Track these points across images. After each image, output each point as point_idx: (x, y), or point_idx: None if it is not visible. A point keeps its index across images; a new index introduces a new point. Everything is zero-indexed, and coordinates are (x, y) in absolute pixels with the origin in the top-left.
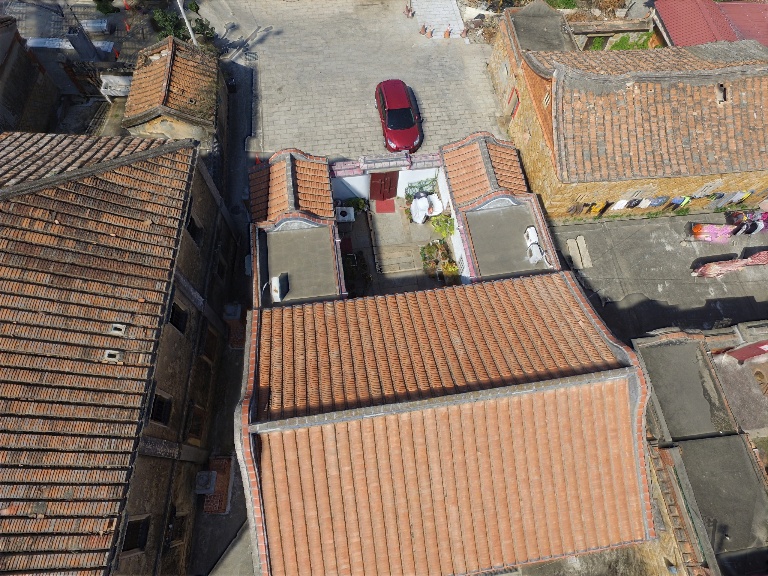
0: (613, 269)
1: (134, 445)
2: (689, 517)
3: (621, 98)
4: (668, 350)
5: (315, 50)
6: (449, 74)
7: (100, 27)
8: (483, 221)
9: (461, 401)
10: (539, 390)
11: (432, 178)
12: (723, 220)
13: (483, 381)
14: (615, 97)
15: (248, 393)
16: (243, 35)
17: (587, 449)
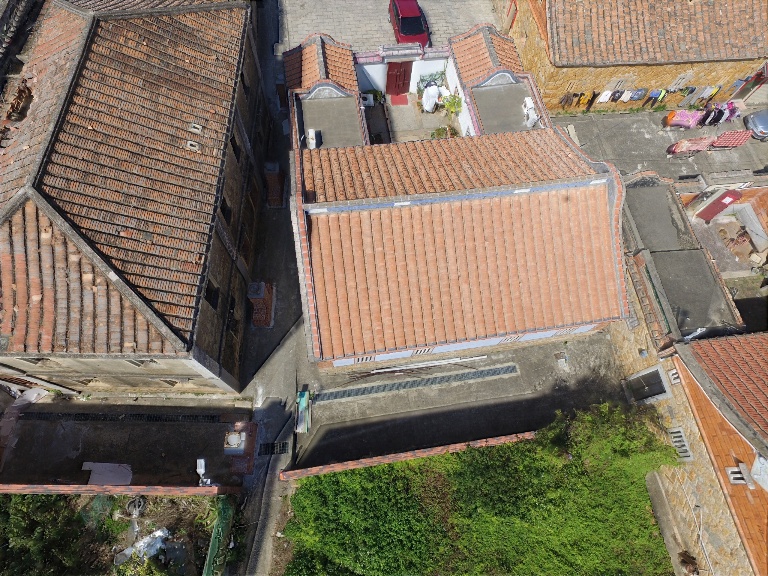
0: (599, 152)
1: (214, 210)
2: (657, 302)
3: None
4: (643, 190)
5: None
6: None
7: None
8: (487, 95)
9: (472, 197)
10: (535, 191)
11: (441, 71)
12: None
13: None
14: None
15: None
16: None
17: (574, 243)
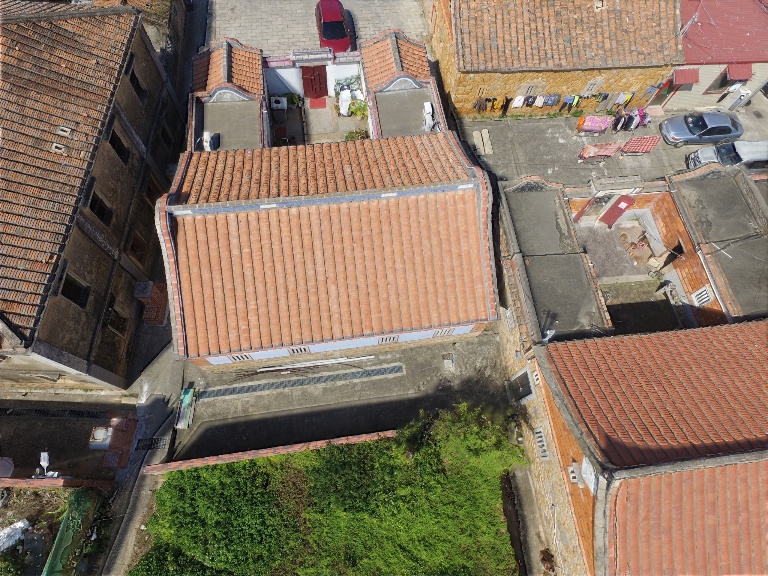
0: (511, 156)
1: (73, 211)
2: (526, 305)
3: (511, 1)
4: (531, 195)
5: None
6: (384, 1)
7: None
8: (390, 100)
9: (339, 200)
10: (403, 195)
11: (356, 75)
12: None
13: None
14: (507, 0)
15: None
16: None
17: (443, 246)
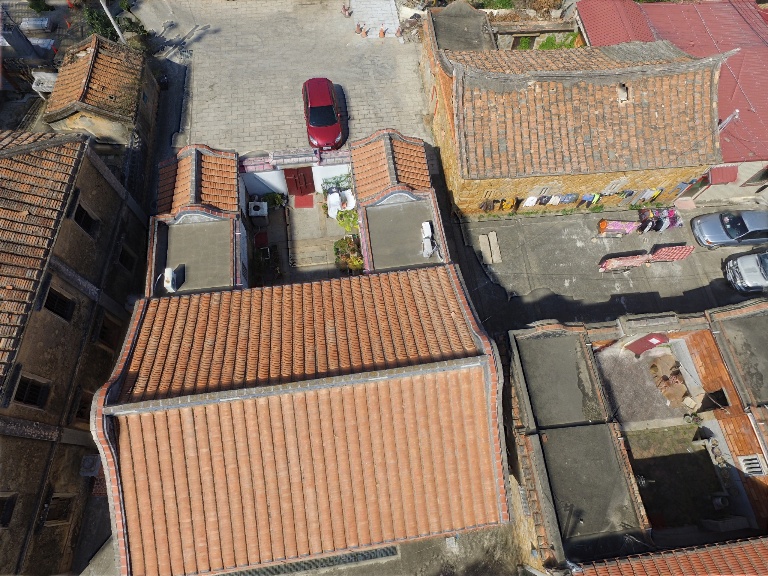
0: (522, 264)
1: None
2: None
3: (523, 97)
4: (548, 342)
5: (250, 48)
6: (380, 73)
7: (41, 25)
8: (383, 216)
9: (317, 387)
10: (394, 377)
11: (346, 174)
12: (636, 217)
13: (343, 368)
14: (517, 96)
15: (113, 377)
16: (180, 33)
17: (443, 435)
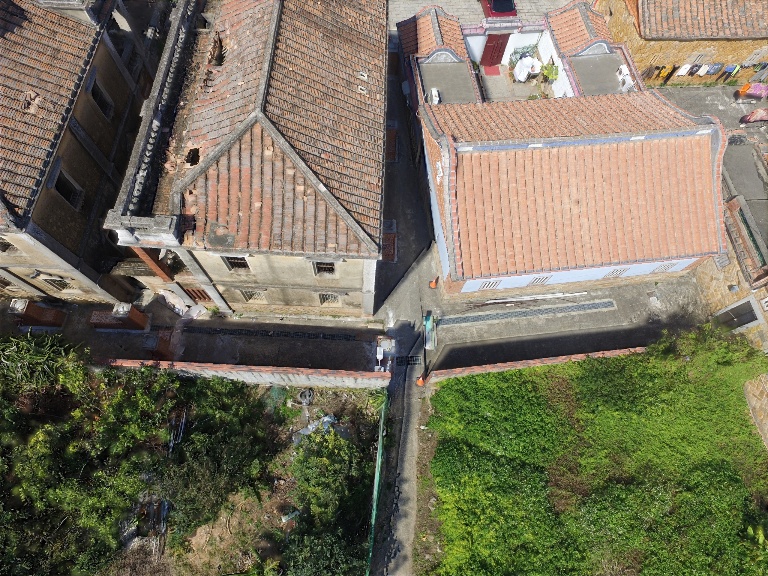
0: None
1: (383, 143)
2: (751, 241)
3: None
4: (731, 148)
5: None
6: None
7: None
8: (584, 63)
9: (594, 142)
10: (648, 139)
11: (534, 44)
12: None
13: None
14: None
15: None
16: None
17: (680, 186)
